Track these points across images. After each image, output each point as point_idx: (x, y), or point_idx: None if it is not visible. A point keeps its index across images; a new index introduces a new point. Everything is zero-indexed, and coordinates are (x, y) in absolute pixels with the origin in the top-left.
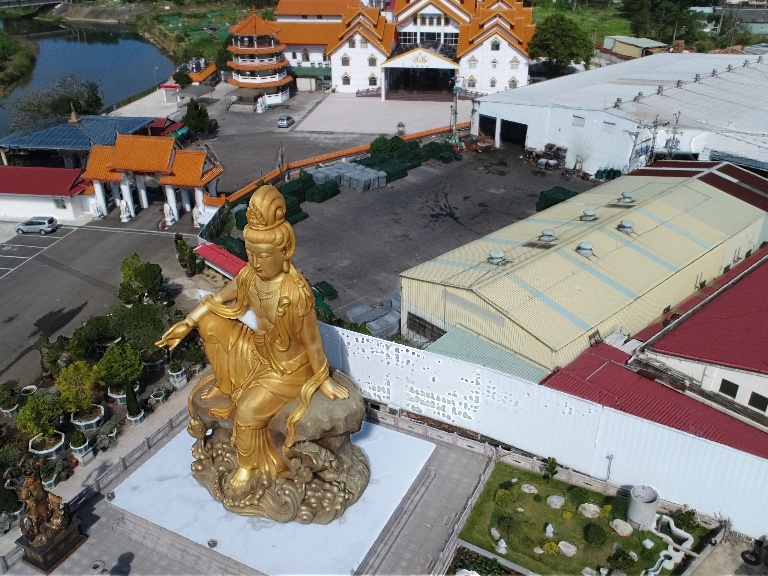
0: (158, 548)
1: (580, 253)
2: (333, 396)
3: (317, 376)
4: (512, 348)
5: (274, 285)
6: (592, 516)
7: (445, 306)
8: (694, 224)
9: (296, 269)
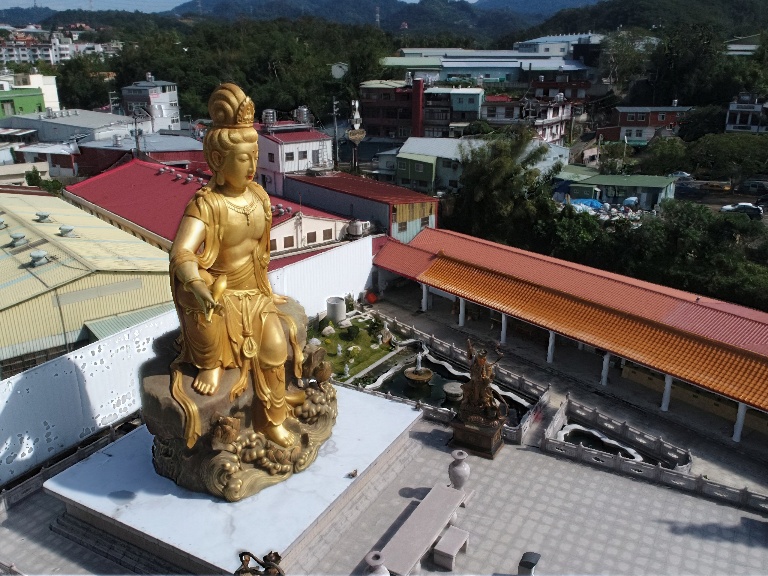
0: (308, 567)
1: (68, 236)
2: (285, 300)
3: (270, 289)
4: (157, 302)
5: (249, 195)
6: (335, 331)
7: (62, 313)
8: (55, 210)
9: None
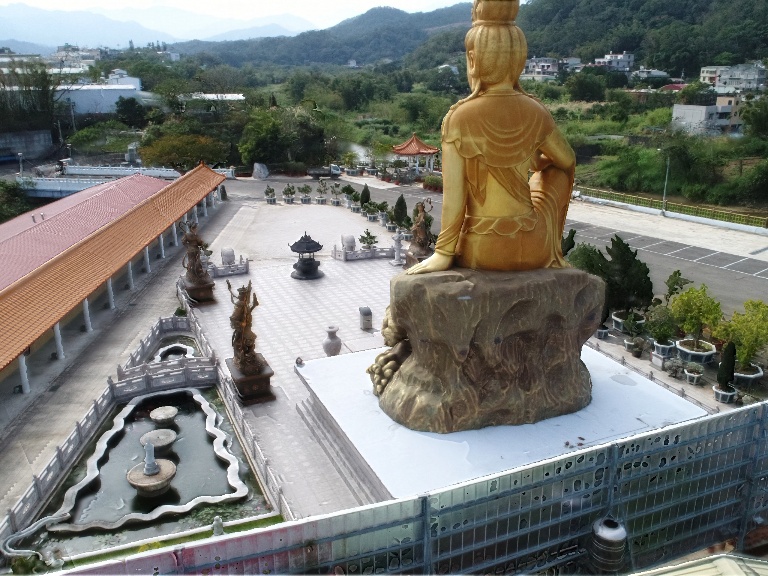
0: None
1: None
2: None
3: None
4: None
5: None
6: None
7: None
8: None
9: (481, 98)
